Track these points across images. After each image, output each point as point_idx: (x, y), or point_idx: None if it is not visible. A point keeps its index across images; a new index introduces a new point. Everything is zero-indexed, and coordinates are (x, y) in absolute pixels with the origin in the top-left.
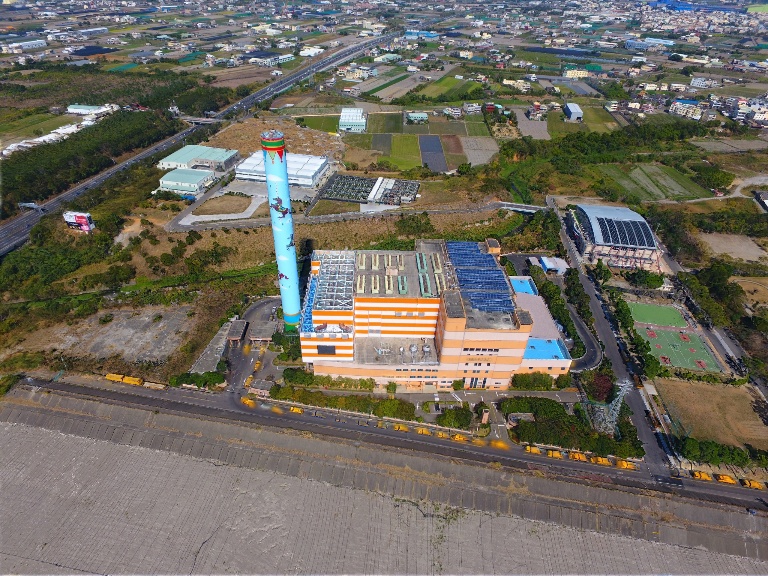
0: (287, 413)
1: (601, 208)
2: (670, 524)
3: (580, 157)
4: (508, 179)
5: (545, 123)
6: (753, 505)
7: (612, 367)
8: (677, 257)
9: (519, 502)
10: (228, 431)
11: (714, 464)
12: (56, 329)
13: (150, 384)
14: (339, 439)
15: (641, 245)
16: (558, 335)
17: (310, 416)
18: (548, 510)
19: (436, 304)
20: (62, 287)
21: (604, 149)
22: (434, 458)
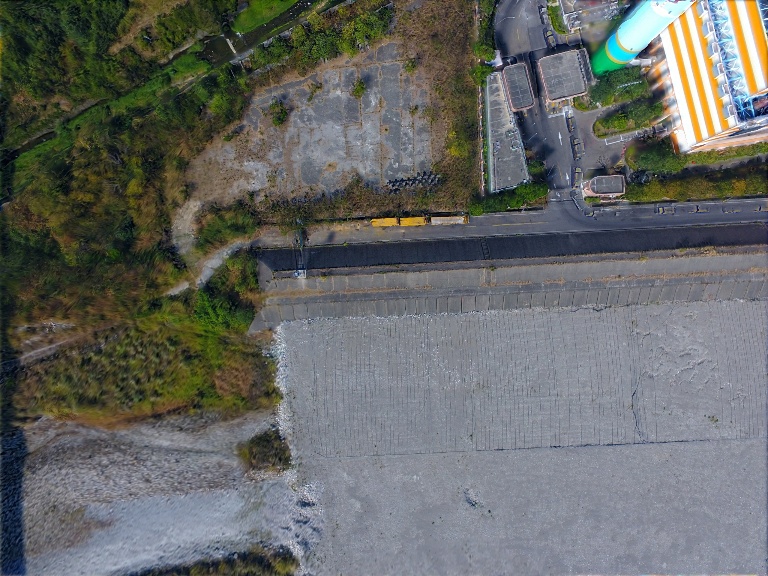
0: (658, 219)
1: None
2: None
3: None
4: None
5: None
6: None
7: None
8: None
9: None
10: (600, 270)
11: None
12: (214, 153)
13: (440, 220)
14: (753, 248)
15: None
16: None
17: (687, 214)
18: None
19: None
20: (136, 57)
21: None
22: None
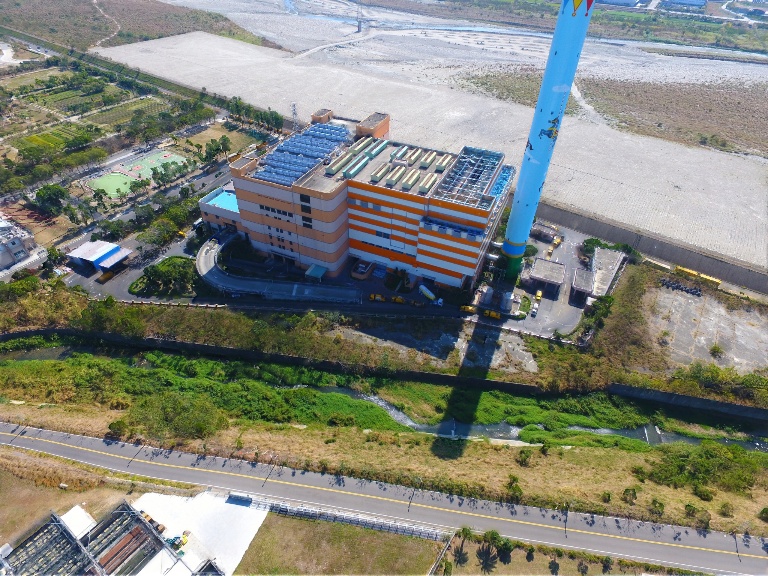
0: None
1: None
2: None
3: None
4: None
5: None
6: None
7: None
8: None
9: None
10: None
11: None
12: None
13: (663, 265)
14: None
15: None
16: None
17: None
18: None
19: None
20: None
21: None
22: None
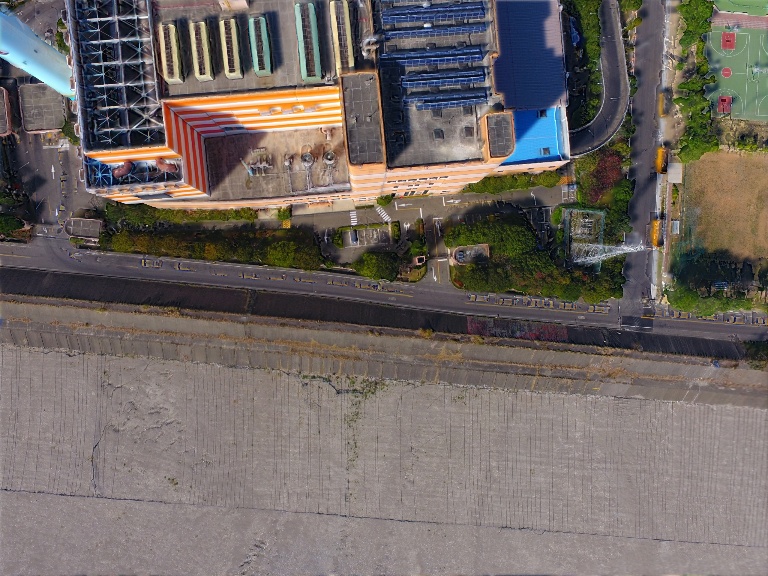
0: None
1: None
2: (615, 380)
3: None
4: None
5: None
6: (722, 350)
7: None
8: None
9: (449, 371)
10: (63, 314)
11: None
12: None
13: None
14: (218, 315)
15: None
16: (562, 95)
17: (173, 269)
18: (481, 376)
19: (334, 94)
20: None
21: None
22: (347, 330)
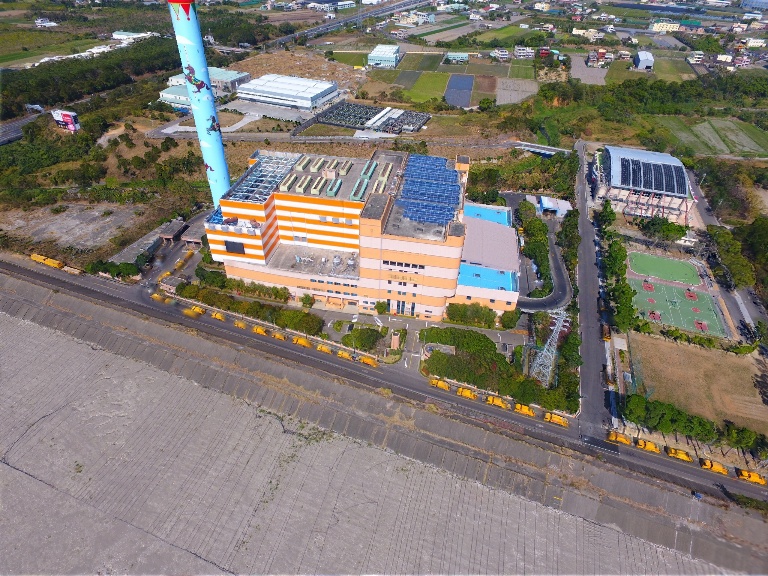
0: (186, 311)
1: (633, 151)
2: (580, 491)
3: (634, 105)
4: (537, 120)
5: (605, 71)
6: (705, 489)
7: (581, 315)
8: (717, 212)
9: (398, 435)
10: (117, 318)
11: (664, 432)
12: (11, 213)
13: (69, 268)
14: (223, 341)
15: (668, 191)
16: (516, 268)
17: (210, 317)
18: (430, 449)
19: None
20: (35, 179)
21: (668, 99)
22: (317, 374)
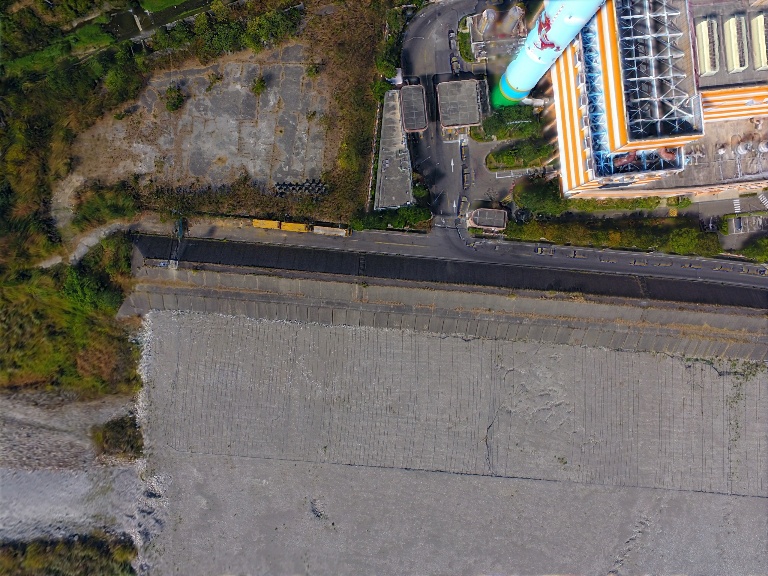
0: (535, 259)
1: None
2: None
3: None
4: None
5: None
6: None
7: None
8: None
9: None
10: (470, 301)
11: None
12: (104, 130)
13: (323, 229)
14: (620, 299)
15: None
16: None
17: (565, 257)
18: None
19: None
20: (35, 19)
21: None
22: (743, 314)
